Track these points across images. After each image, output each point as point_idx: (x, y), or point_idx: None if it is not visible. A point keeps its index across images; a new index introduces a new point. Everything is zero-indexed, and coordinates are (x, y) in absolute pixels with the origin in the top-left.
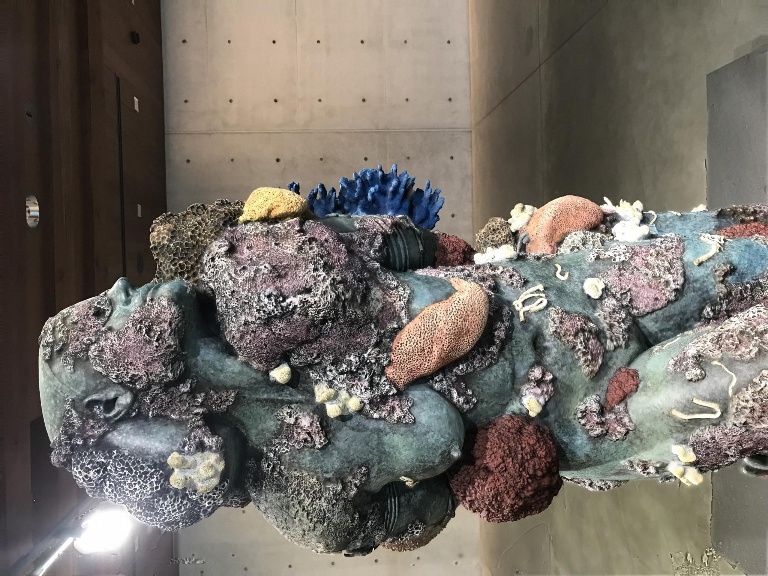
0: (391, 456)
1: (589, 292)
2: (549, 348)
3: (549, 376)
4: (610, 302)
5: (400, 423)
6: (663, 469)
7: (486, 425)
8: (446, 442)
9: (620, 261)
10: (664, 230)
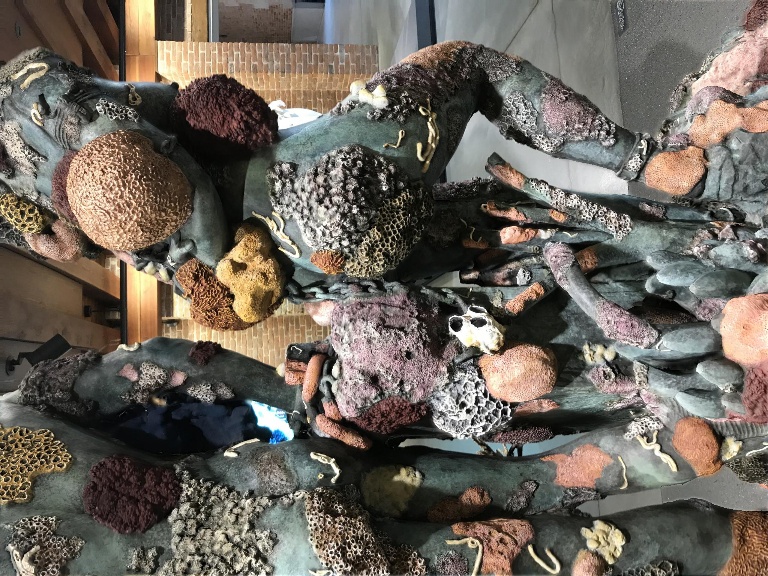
0: None
1: None
2: None
3: None
4: None
5: None
6: (360, 104)
7: None
8: None
9: None
10: None
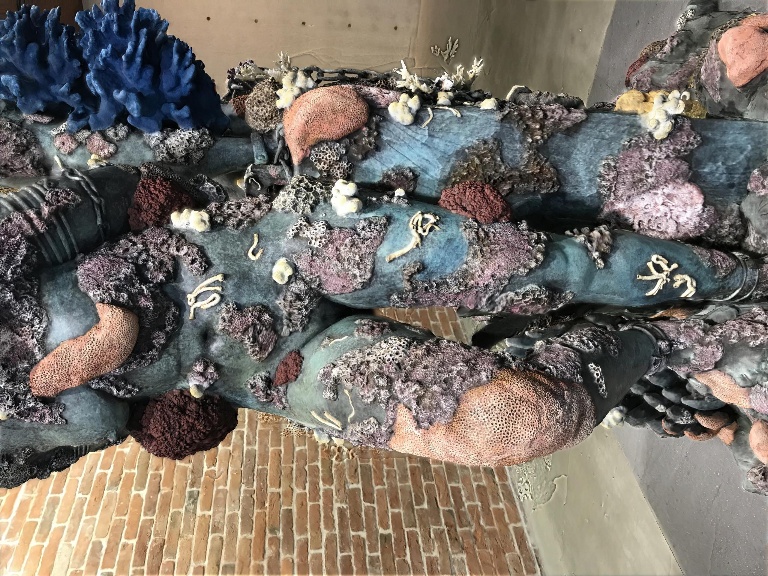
0: (51, 441)
1: (274, 279)
2: (217, 341)
3: (211, 370)
4: (297, 287)
5: (53, 424)
6: None
7: (157, 397)
8: (100, 433)
9: (314, 247)
10: (436, 134)
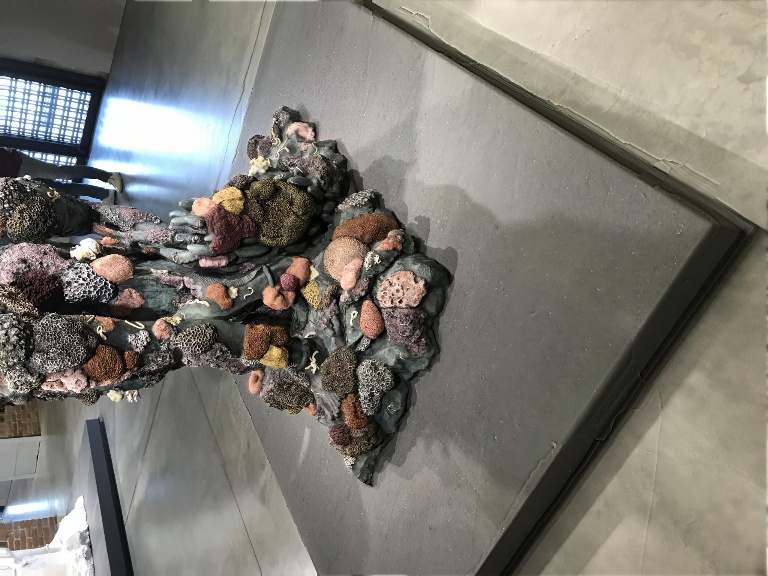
0: None
1: None
2: None
3: None
4: None
5: None
6: None
7: None
8: None
9: None
10: None
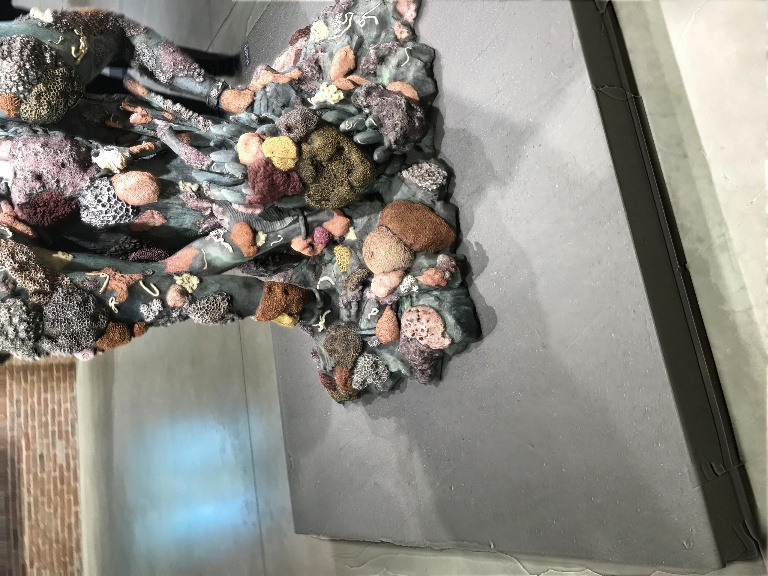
0: None
1: None
2: None
3: None
4: None
5: None
6: None
7: None
8: None
9: None
10: None
